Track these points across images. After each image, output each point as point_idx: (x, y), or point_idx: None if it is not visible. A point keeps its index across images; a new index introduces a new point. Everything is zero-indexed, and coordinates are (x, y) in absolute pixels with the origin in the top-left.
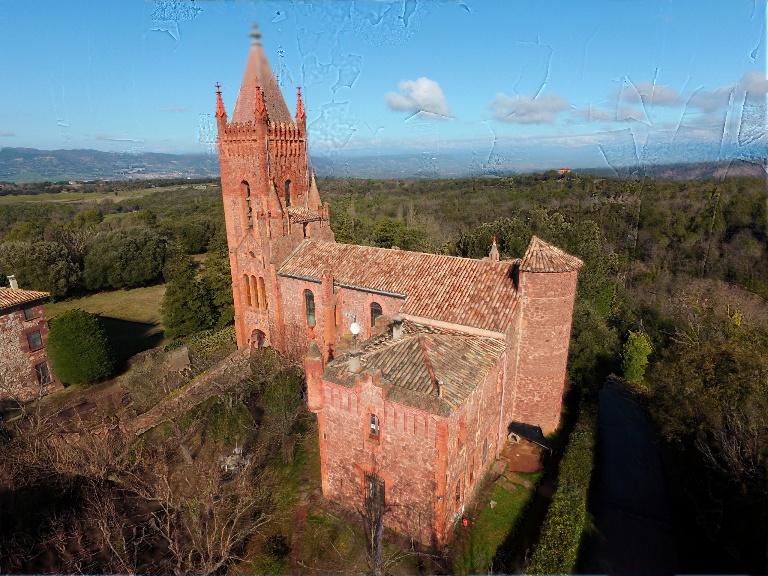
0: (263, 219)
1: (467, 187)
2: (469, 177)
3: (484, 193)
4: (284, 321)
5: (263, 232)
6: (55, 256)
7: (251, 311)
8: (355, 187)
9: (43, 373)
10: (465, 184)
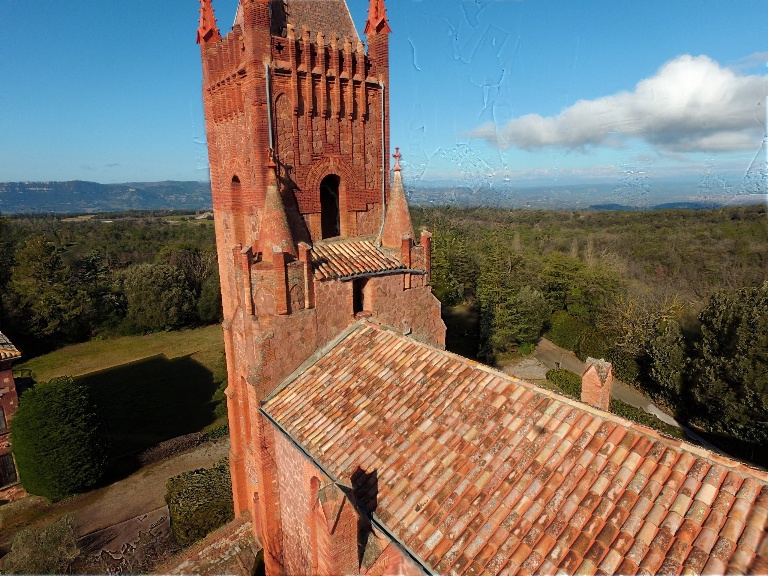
0: (240, 268)
1: (694, 216)
2: (699, 201)
3: (743, 225)
4: (282, 523)
5: (242, 300)
6: (171, 281)
7: (251, 454)
8: (516, 212)
9: (5, 469)
10: (691, 211)
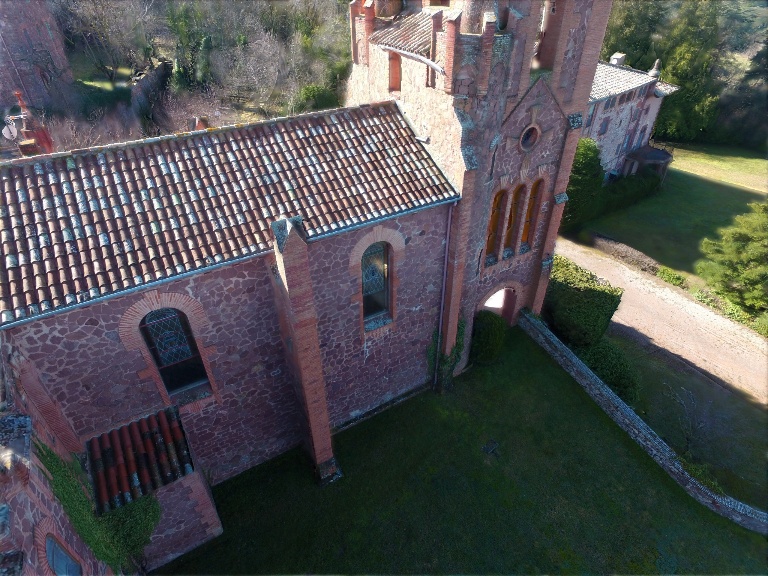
0: None
1: None
2: None
3: None
4: None
5: None
6: None
7: None
8: None
9: None
10: None
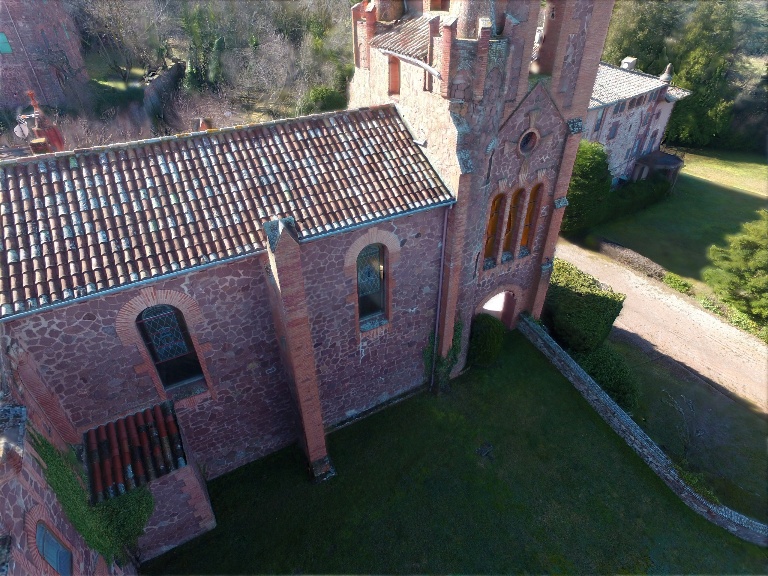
0: None
1: None
2: None
3: None
4: None
5: None
6: None
7: None
8: None
9: None
10: None
